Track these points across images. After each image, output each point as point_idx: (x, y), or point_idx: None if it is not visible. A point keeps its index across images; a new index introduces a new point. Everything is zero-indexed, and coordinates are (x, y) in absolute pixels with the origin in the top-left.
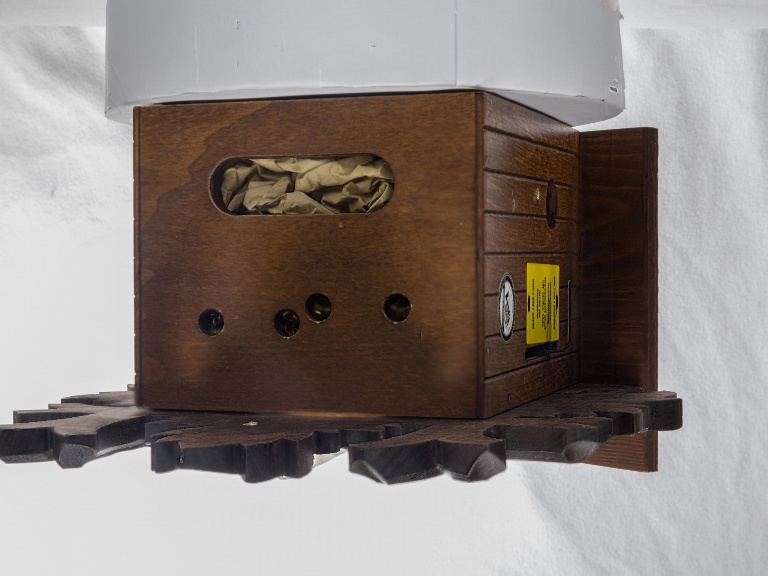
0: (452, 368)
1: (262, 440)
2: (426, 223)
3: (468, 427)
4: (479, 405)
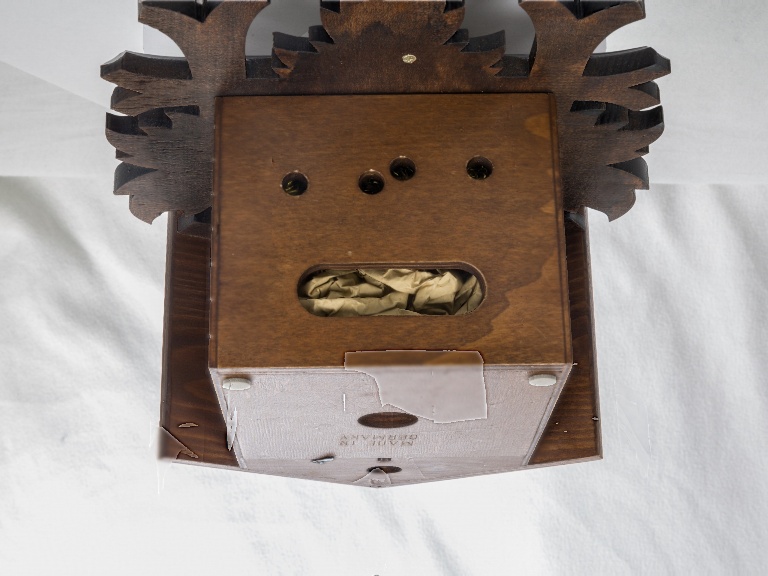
0: (244, 136)
1: (351, 3)
2: (266, 255)
3: (208, 68)
4: (220, 107)
